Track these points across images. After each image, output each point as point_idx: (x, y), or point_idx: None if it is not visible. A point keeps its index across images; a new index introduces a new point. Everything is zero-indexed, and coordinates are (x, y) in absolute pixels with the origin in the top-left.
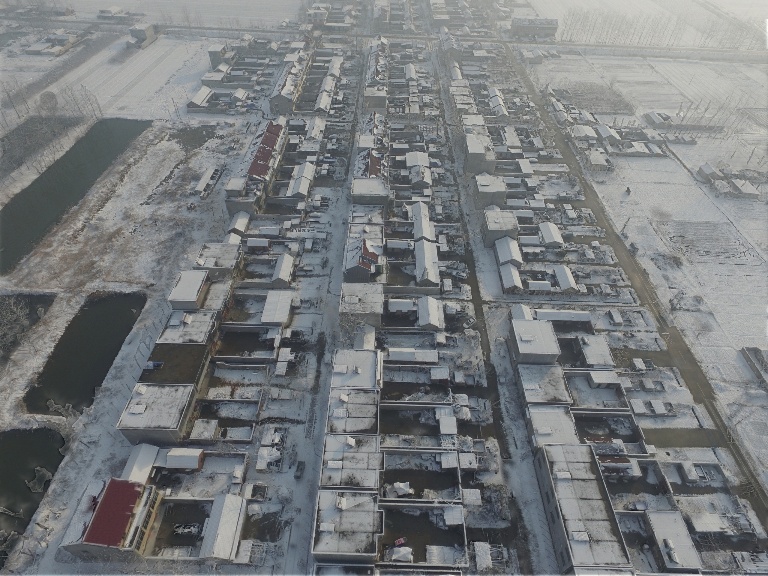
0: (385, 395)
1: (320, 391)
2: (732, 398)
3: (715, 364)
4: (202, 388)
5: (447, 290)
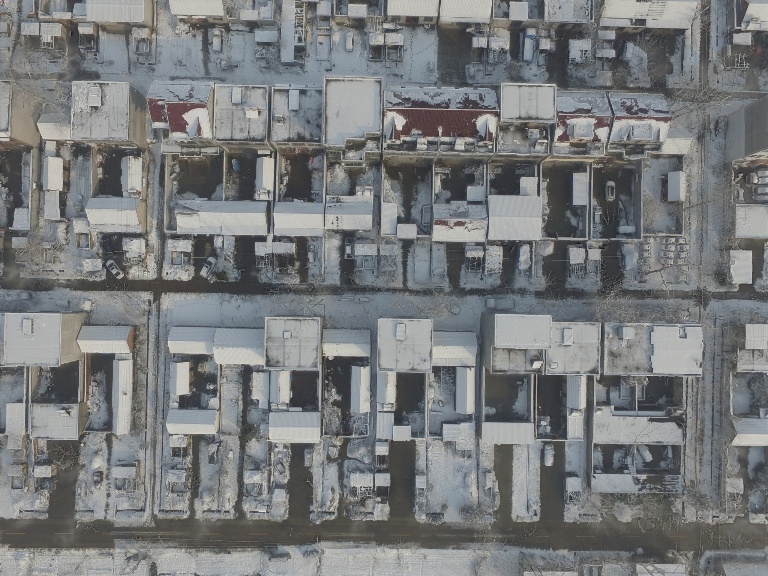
0: (6, 156)
1: None
2: (7, 566)
3: (56, 571)
4: None
5: (168, 243)
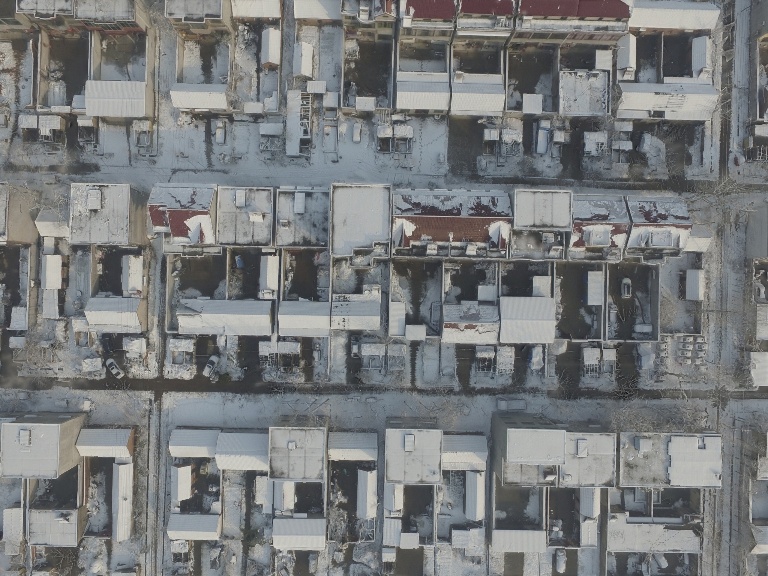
0: (3, 251)
1: (7, 173)
2: None
3: None
4: (8, 33)
5: (170, 343)
